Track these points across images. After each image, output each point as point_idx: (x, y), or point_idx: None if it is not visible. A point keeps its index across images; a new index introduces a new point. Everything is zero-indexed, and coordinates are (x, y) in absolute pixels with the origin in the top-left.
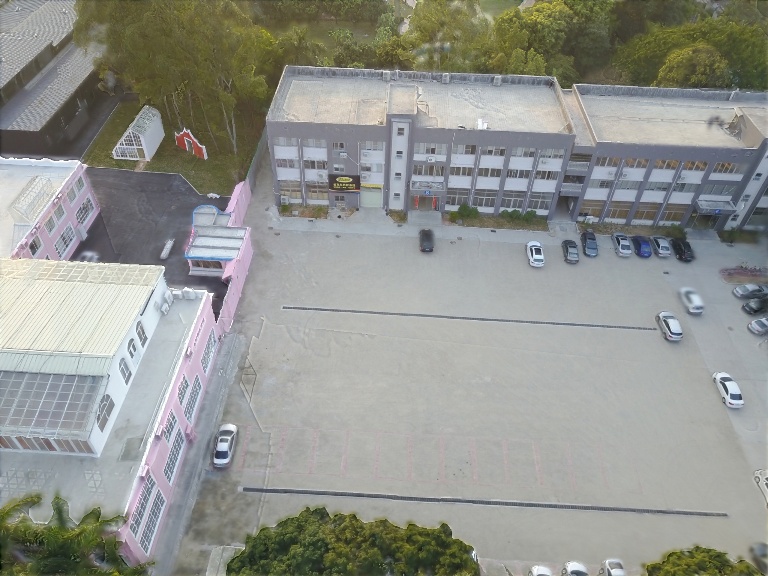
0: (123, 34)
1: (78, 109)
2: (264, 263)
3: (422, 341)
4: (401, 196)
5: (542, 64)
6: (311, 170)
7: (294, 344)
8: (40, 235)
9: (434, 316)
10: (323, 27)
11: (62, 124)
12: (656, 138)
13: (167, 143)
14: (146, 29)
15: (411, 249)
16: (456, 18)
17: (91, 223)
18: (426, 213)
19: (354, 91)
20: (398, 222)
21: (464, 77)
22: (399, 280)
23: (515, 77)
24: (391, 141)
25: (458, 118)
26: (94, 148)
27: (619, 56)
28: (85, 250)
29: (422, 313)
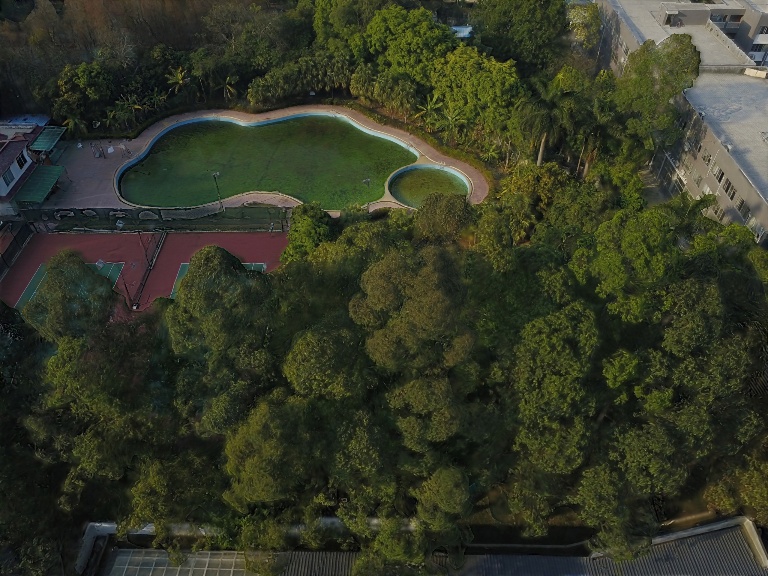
0: None
1: None
2: None
3: None
4: None
5: None
6: None
7: None
8: None
9: None
10: None
11: None
12: (708, 50)
13: None
14: None
15: None
16: None
17: None
18: None
19: None
20: None
21: None
22: None
23: None
24: None
25: None
26: None
27: (506, 56)
28: None
29: None
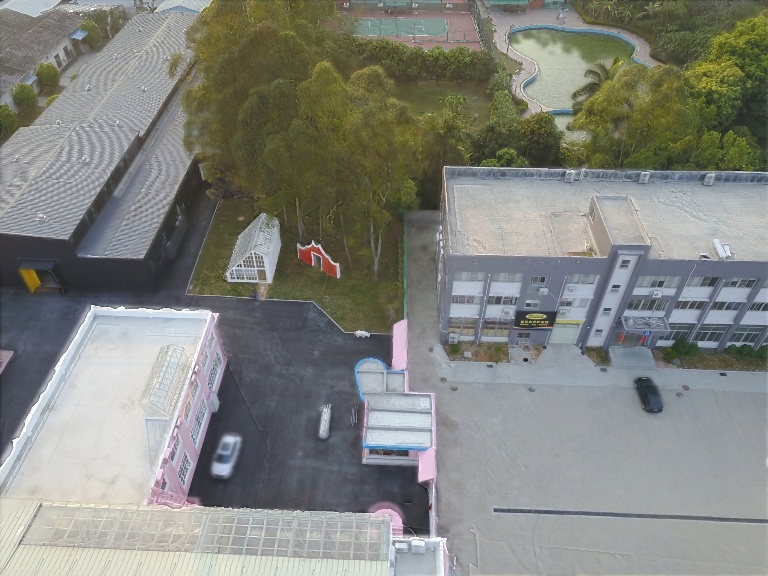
0: (259, 145)
1: (177, 217)
2: (450, 436)
3: (696, 563)
4: (604, 332)
5: (746, 150)
6: (494, 306)
7: (528, 575)
8: (179, 431)
9: (696, 518)
10: (423, 88)
11: (164, 241)
12: None
13: (286, 255)
14: (294, 141)
15: (631, 408)
16: (664, 106)
17: (220, 382)
18: (632, 350)
19: (536, 199)
20: (600, 365)
21: (666, 175)
22: (631, 458)
23: (731, 174)
24: (611, 275)
25: (683, 237)
26: (201, 267)
27: None
28: (220, 427)
29: (679, 513)
